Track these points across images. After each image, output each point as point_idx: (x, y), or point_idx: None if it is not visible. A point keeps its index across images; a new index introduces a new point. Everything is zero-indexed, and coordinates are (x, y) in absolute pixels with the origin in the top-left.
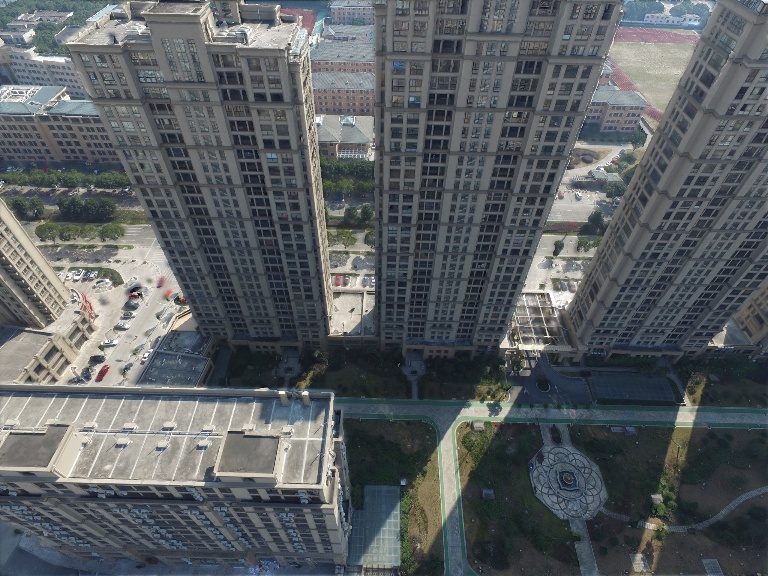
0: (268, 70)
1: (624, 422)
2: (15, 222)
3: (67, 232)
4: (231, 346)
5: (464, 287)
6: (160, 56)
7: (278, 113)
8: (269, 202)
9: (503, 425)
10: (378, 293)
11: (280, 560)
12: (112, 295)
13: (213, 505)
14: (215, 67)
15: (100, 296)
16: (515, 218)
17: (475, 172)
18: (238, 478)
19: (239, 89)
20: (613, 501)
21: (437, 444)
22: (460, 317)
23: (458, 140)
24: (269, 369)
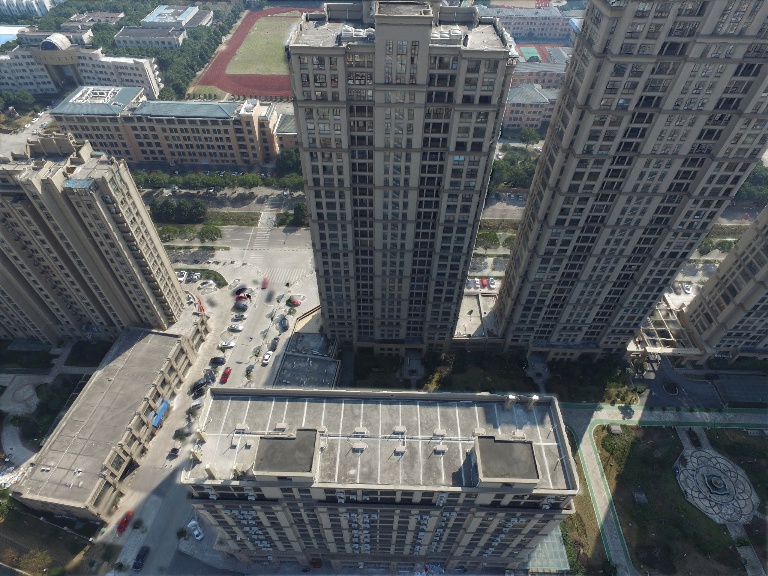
0: (485, 72)
1: (760, 425)
2: (150, 224)
3: (167, 233)
4: (355, 348)
5: (608, 290)
6: (379, 58)
7: (480, 115)
8: (441, 204)
9: (640, 428)
10: (516, 295)
11: (452, 564)
12: (218, 297)
13: (442, 510)
14: (429, 69)
15: (207, 298)
16: (685, 221)
17: (659, 175)
18: (499, 483)
19: (446, 91)
20: (767, 505)
21: (577, 447)
22: (592, 320)
23: (653, 142)
24: (394, 371)
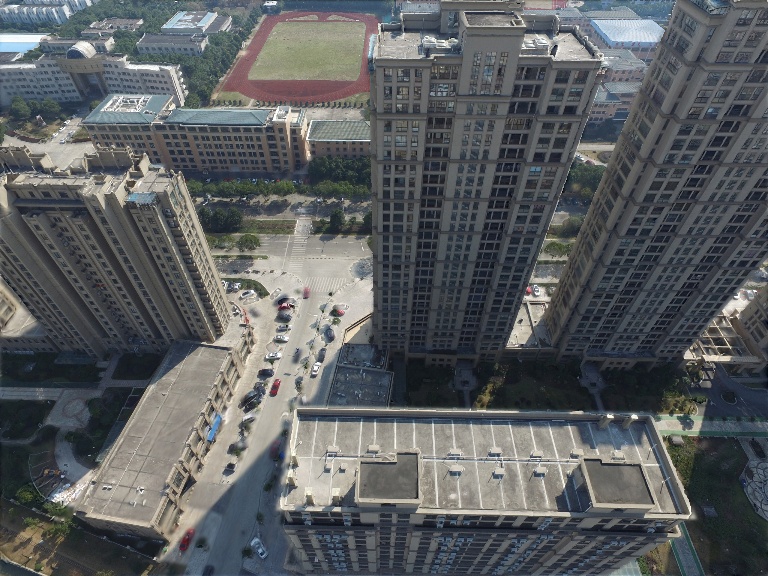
0: (574, 82)
1: None
2: (202, 236)
3: None
4: (406, 359)
5: (671, 299)
6: (465, 69)
7: (563, 126)
8: (511, 215)
9: (702, 439)
10: (575, 305)
11: None
12: (261, 307)
13: None
14: (515, 80)
15: (249, 308)
16: (760, 229)
17: (738, 183)
18: (611, 509)
19: (529, 102)
20: None
21: None
22: None
23: (736, 151)
24: (446, 382)
